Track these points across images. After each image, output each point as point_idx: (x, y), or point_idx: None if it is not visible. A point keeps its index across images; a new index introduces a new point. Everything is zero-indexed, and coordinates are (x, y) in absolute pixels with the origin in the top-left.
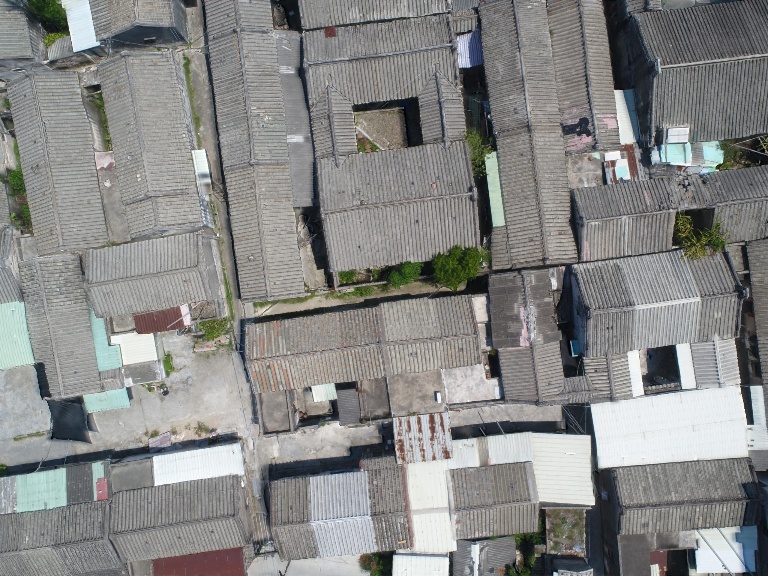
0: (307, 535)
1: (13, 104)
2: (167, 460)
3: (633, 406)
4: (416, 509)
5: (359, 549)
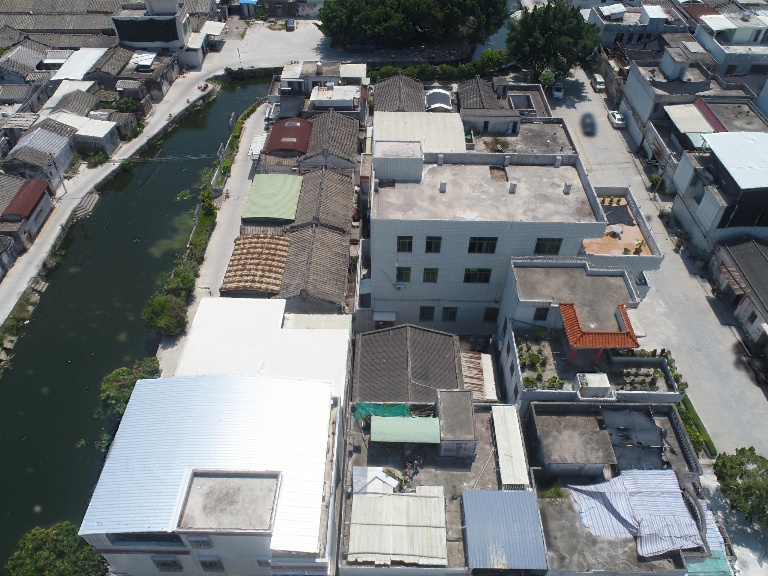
0: (33, 151)
1: None
2: None
3: (60, 71)
4: None
5: None
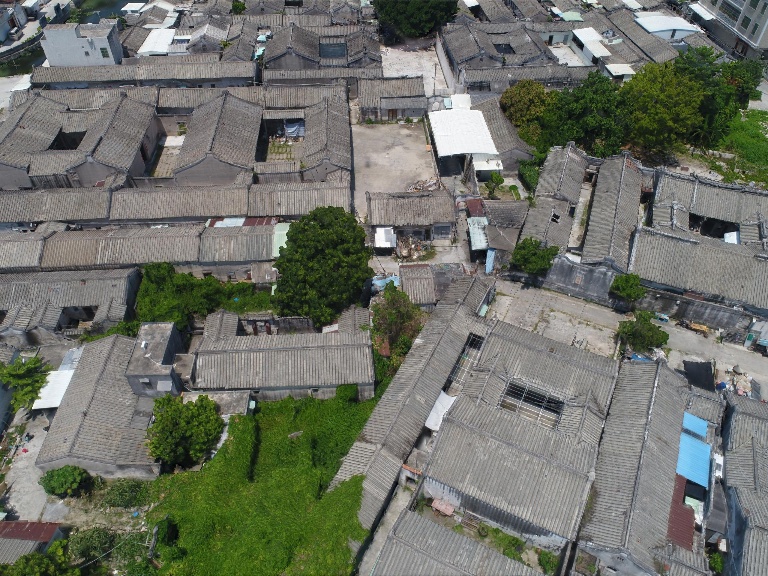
0: None
1: None
2: None
3: (171, 35)
4: (159, 2)
5: None
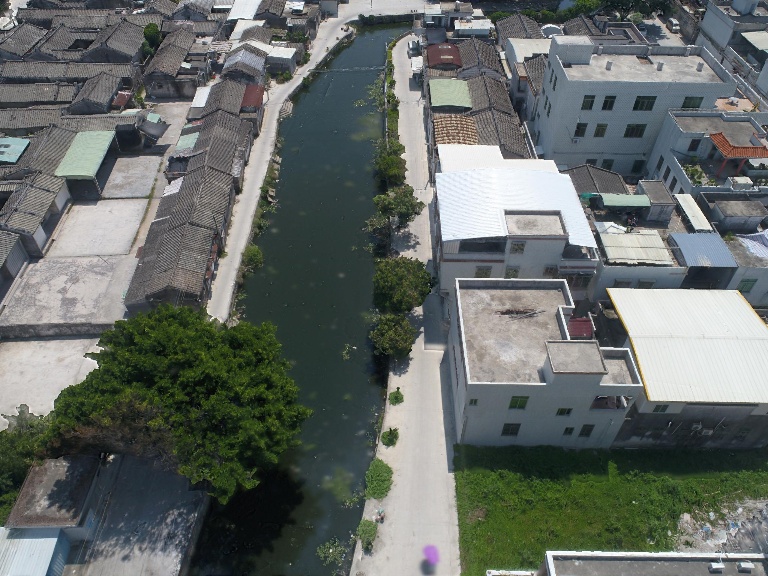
0: (246, 65)
1: None
2: (194, 105)
3: None
4: None
5: (261, 61)
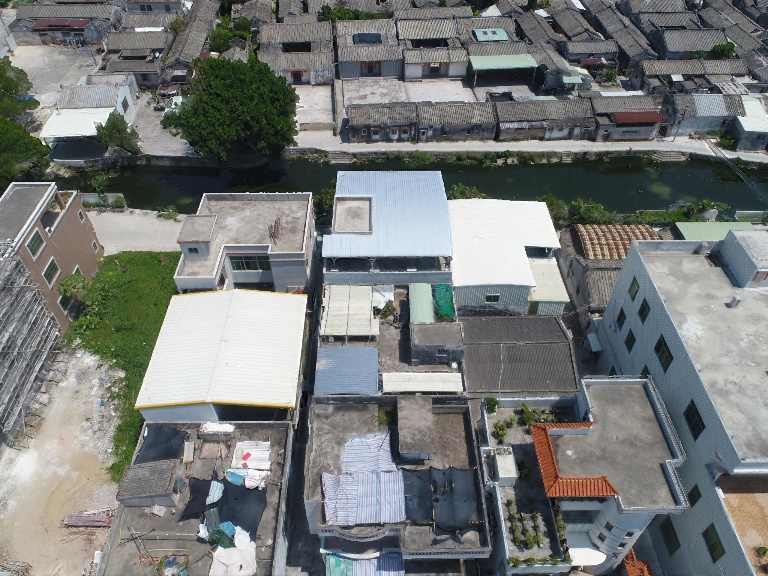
0: (691, 102)
1: (520, 20)
2: None
3: None
4: None
5: (718, 113)
